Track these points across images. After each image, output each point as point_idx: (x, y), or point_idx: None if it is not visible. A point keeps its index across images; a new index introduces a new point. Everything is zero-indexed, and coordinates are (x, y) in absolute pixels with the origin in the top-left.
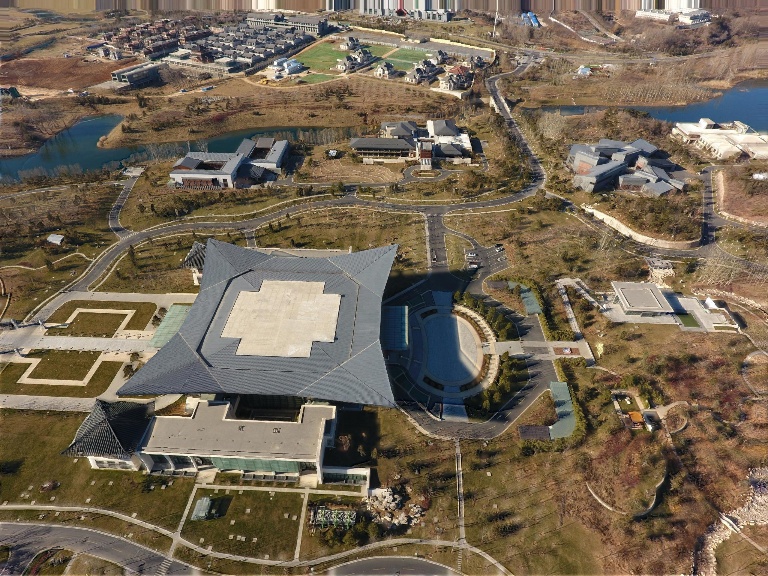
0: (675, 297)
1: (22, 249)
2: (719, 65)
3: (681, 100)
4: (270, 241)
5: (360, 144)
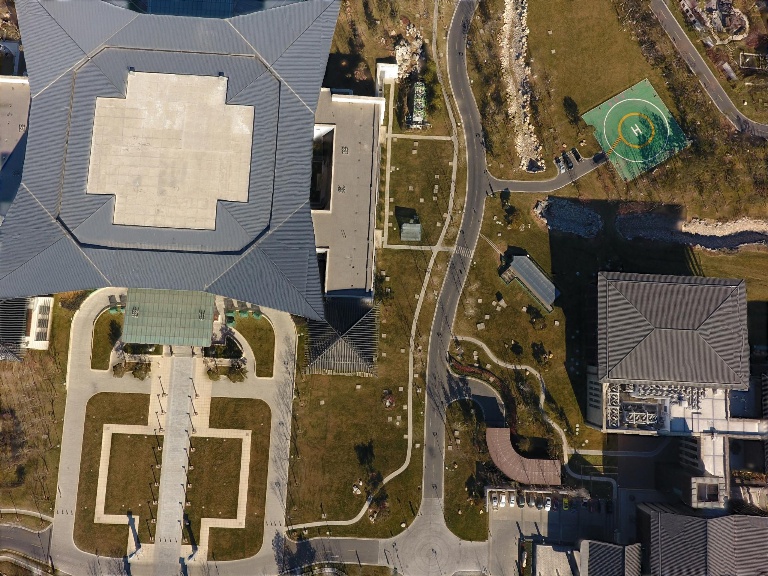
0: None
1: None
2: None
3: None
4: None
5: None
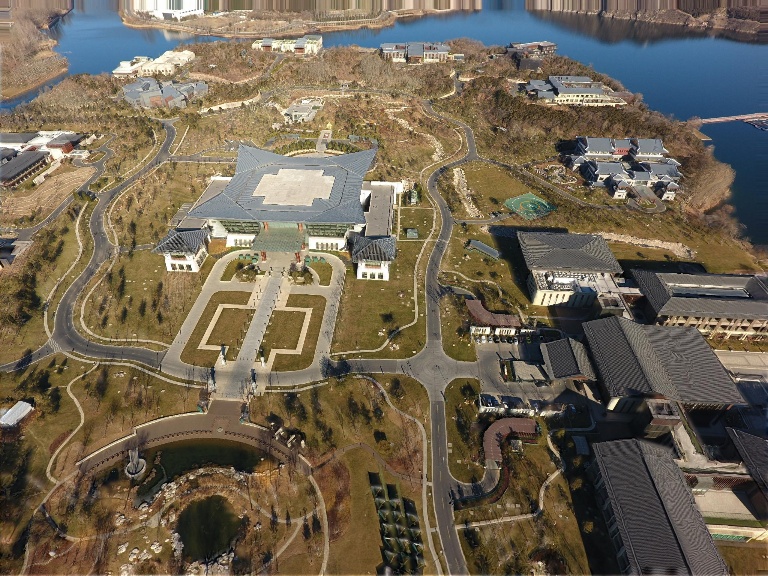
0: None
1: (13, 456)
2: (30, 40)
3: (59, 67)
4: (148, 236)
5: (6, 174)
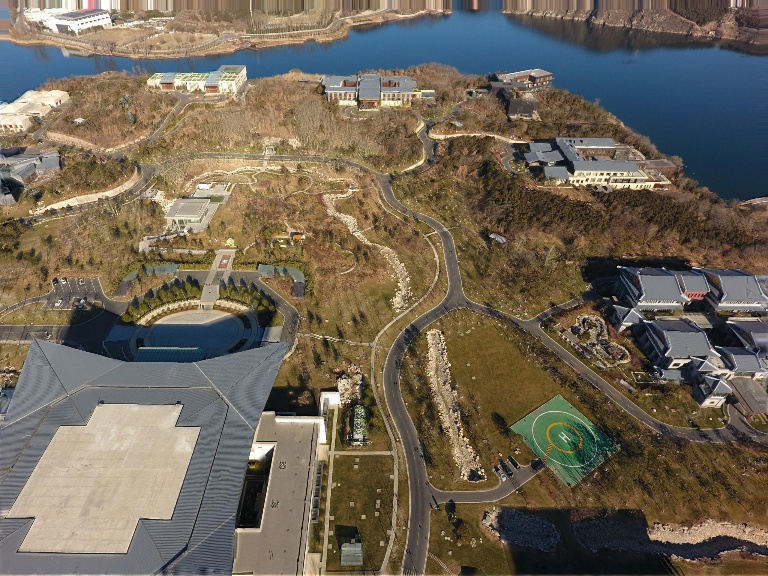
0: (192, 197)
1: None
2: None
3: None
4: None
5: None
